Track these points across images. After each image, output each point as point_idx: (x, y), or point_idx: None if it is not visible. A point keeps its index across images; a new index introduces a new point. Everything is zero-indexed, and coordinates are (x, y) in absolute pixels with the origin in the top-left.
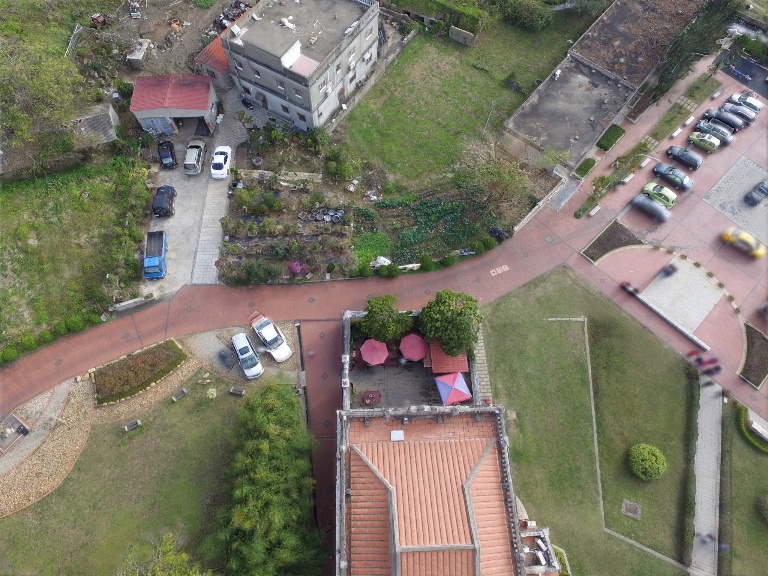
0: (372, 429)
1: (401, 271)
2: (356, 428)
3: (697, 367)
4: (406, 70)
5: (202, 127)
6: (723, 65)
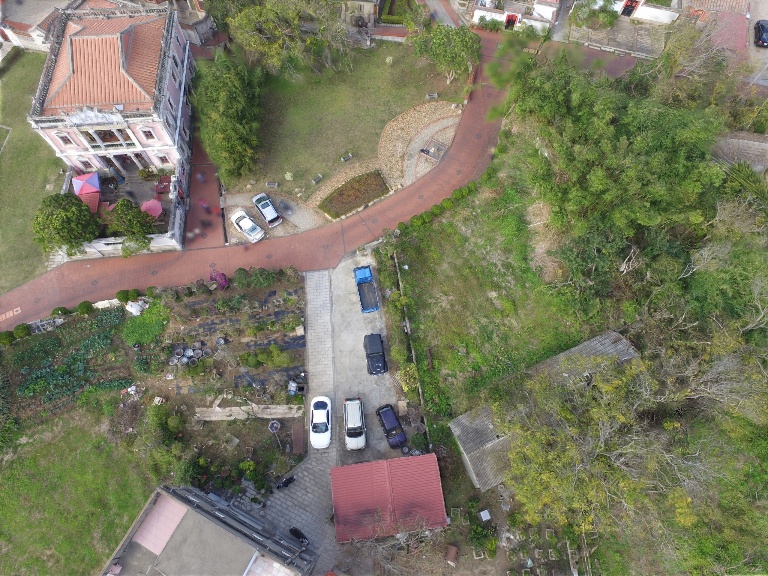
0: None
1: None
2: None
3: None
4: None
5: None
6: None
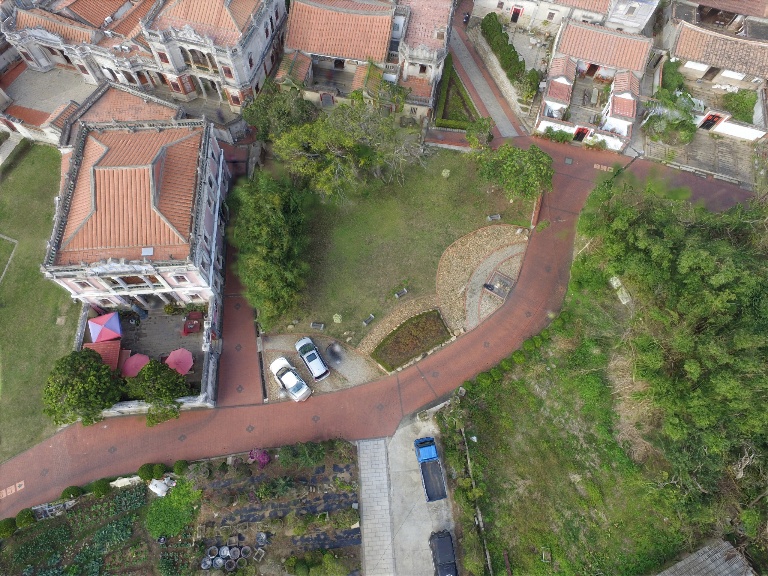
0: None
1: None
2: (183, 257)
3: None
4: None
5: None
6: None
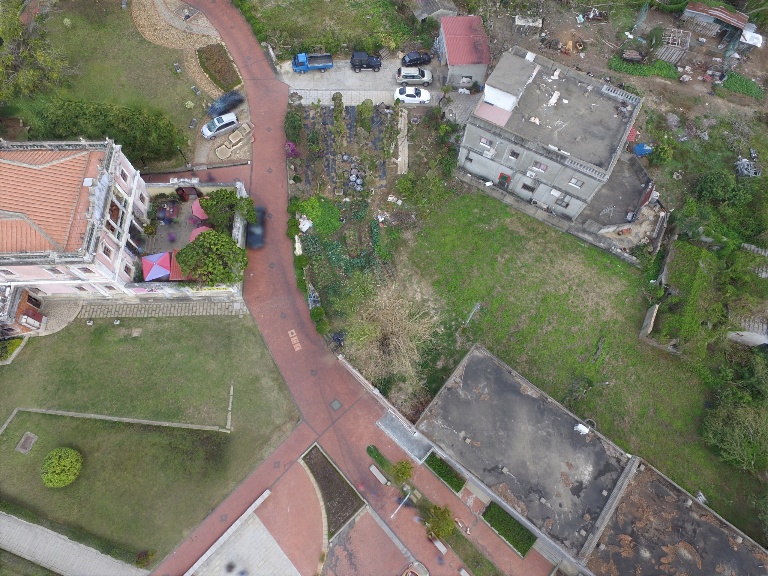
0: None
1: None
2: (103, 156)
3: (153, 571)
4: (572, 255)
5: None
6: None
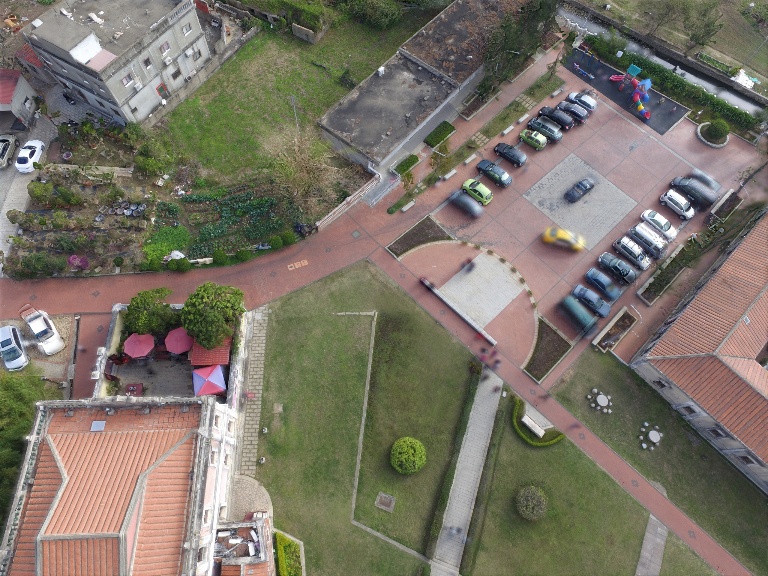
0: (75, 419)
1: (195, 265)
2: (58, 418)
3: (482, 361)
4: (242, 66)
5: (20, 122)
6: (559, 63)
